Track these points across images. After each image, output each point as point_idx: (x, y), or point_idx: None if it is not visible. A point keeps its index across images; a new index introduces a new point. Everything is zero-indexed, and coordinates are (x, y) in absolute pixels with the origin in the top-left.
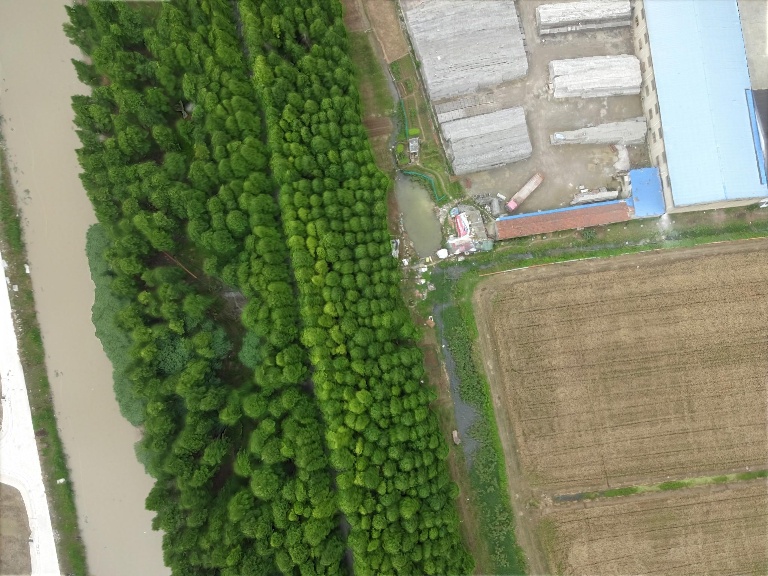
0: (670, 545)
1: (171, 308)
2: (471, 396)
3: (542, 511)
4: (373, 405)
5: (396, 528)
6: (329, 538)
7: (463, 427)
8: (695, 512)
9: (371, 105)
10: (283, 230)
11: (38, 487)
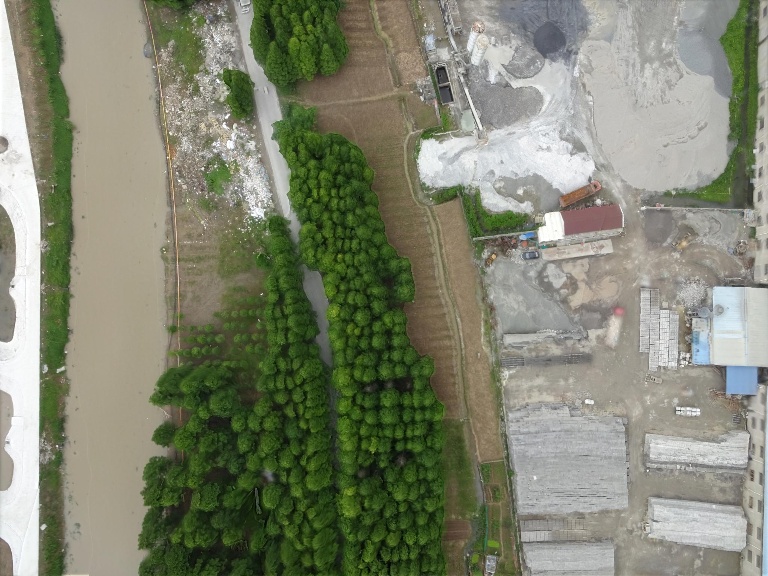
0: None
1: None
2: None
3: None
4: None
5: None
6: None
7: None
8: None
9: (453, 504)
10: None
11: None
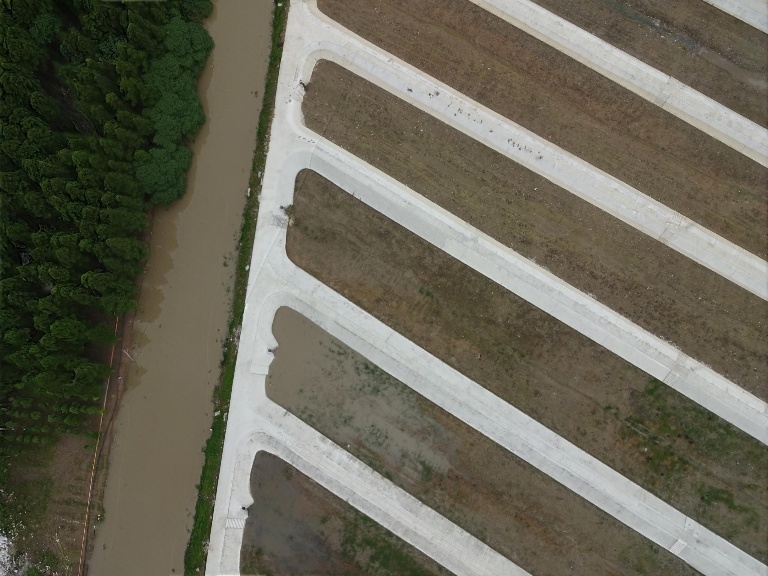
0: None
1: None
2: None
3: None
4: None
5: None
6: None
7: None
8: None
9: None
10: None
11: (295, 2)
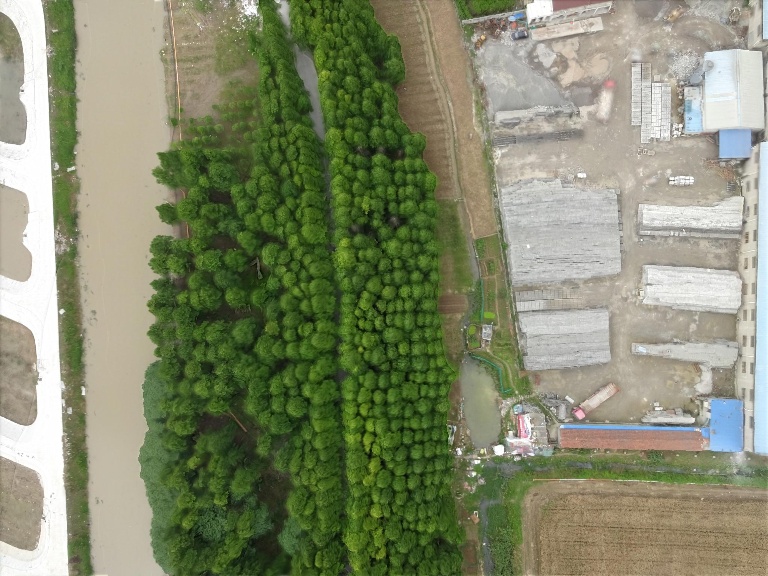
0: None
1: (218, 484)
2: None
3: None
4: None
5: None
6: None
7: None
8: None
9: (449, 280)
10: (341, 420)
11: None
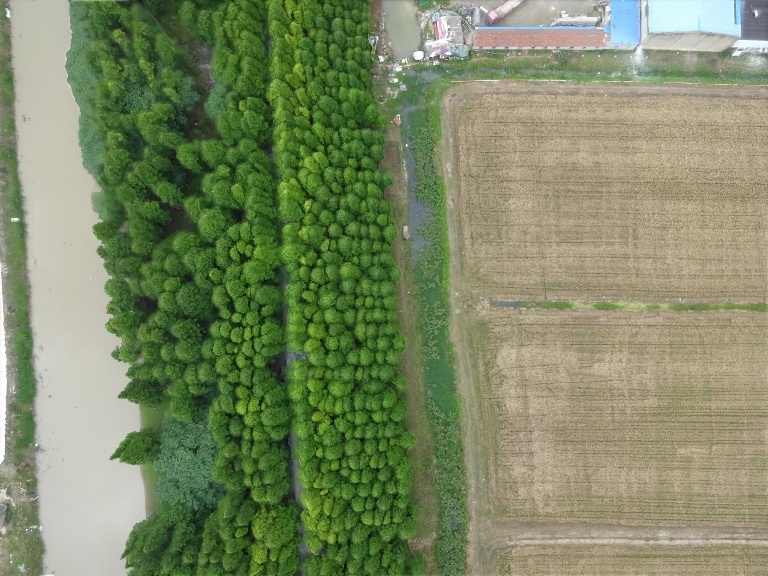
0: (596, 360)
1: (143, 44)
2: (426, 195)
3: (478, 312)
4: (328, 167)
5: (334, 288)
6: (267, 283)
7: (414, 224)
8: (624, 332)
9: None
10: None
11: None
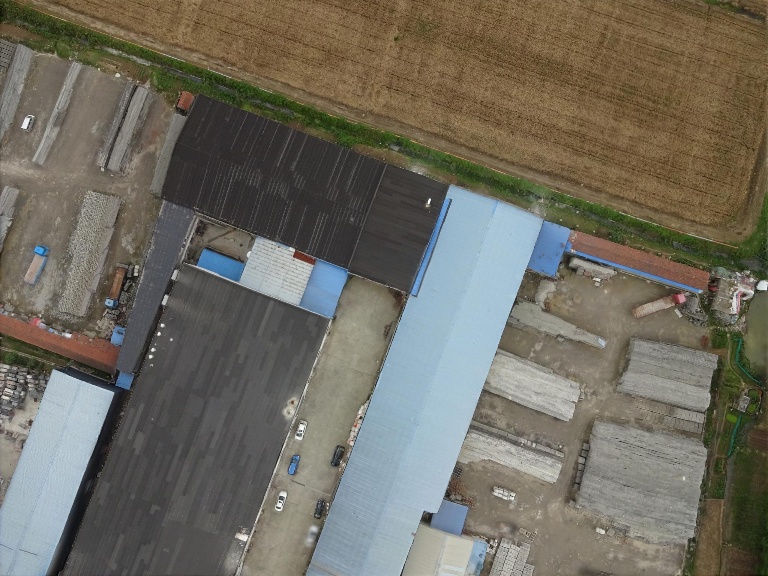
0: None
1: None
2: None
3: None
4: None
5: None
6: None
7: None
8: None
9: (761, 466)
10: None
11: None
